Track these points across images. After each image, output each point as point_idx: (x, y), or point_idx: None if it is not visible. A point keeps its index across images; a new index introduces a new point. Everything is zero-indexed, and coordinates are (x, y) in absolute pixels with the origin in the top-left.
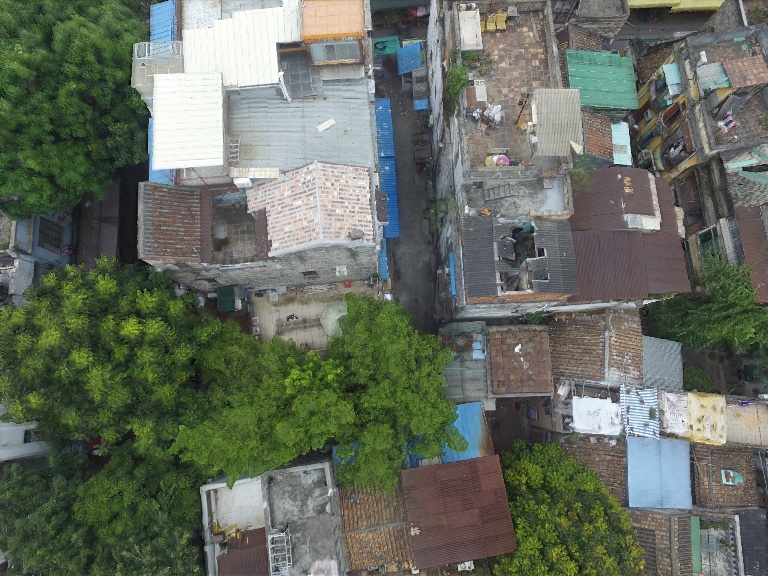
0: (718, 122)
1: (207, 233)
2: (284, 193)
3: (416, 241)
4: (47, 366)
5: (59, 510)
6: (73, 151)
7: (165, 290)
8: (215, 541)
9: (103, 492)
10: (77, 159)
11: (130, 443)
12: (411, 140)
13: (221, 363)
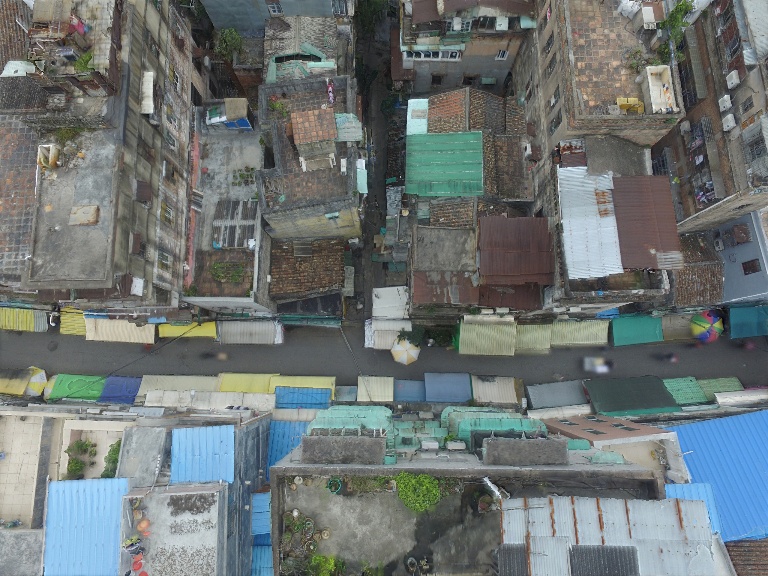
0: None
1: None
2: None
3: None
4: None
5: None
6: None
7: None
8: None
9: None
10: None
11: None
12: None
13: None
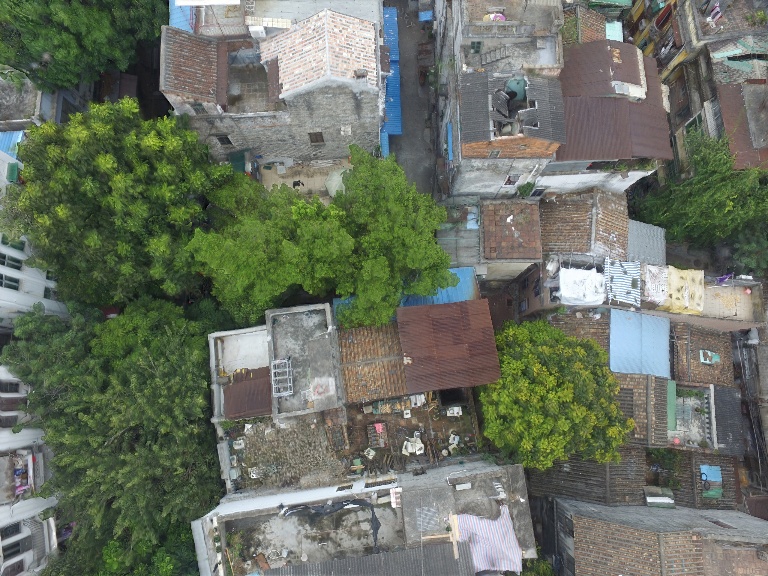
0: (707, 18)
1: (223, 79)
2: (295, 41)
3: (417, 148)
4: (73, 185)
5: (77, 344)
6: (98, 14)
7: (182, 132)
8: (221, 382)
9: (119, 327)
10: (102, 20)
11: (143, 298)
12: (416, 56)
13: (232, 202)
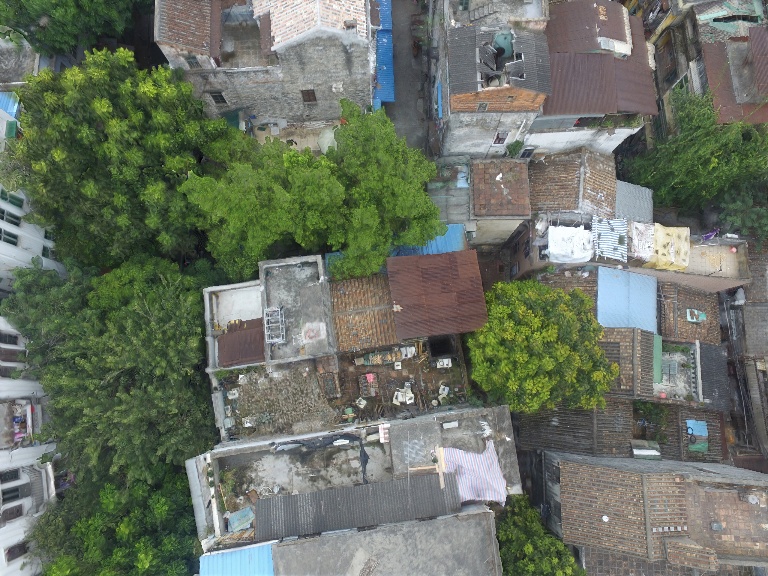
0: None
1: (216, 32)
2: None
3: (411, 118)
4: (70, 133)
5: (75, 297)
6: None
7: None
8: (216, 335)
9: (115, 280)
10: None
11: (140, 255)
12: (409, 28)
13: (226, 154)
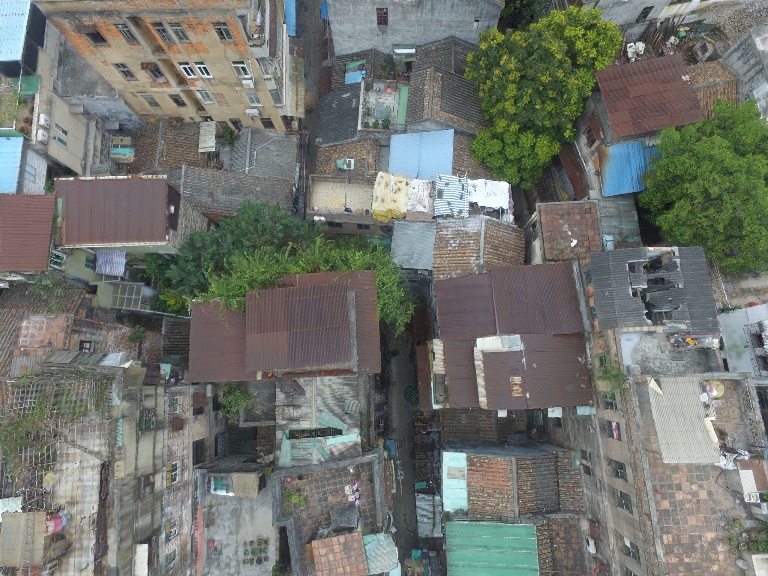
0: None
1: None
2: None
3: None
4: None
5: None
6: None
7: None
8: None
9: None
10: None
11: None
12: None
13: None
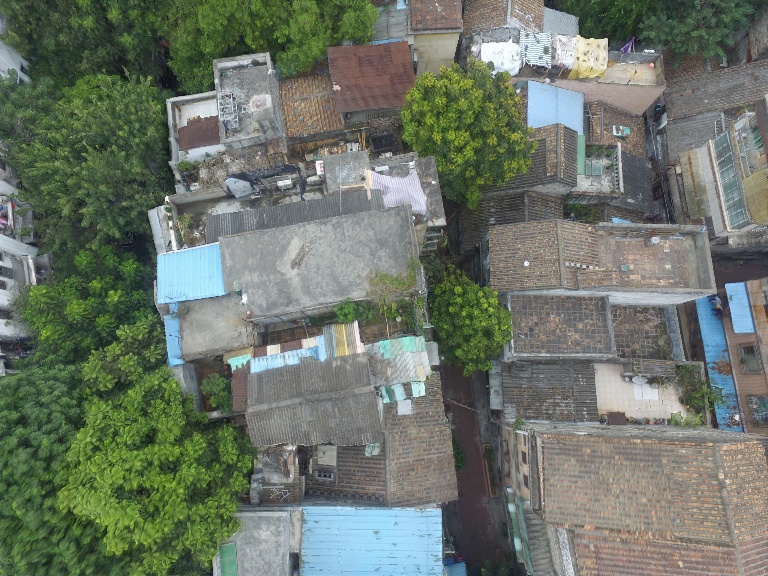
0: None
1: None
2: None
3: None
4: None
5: None
6: None
7: None
8: None
9: (84, 84)
10: None
11: None
12: None
13: None
